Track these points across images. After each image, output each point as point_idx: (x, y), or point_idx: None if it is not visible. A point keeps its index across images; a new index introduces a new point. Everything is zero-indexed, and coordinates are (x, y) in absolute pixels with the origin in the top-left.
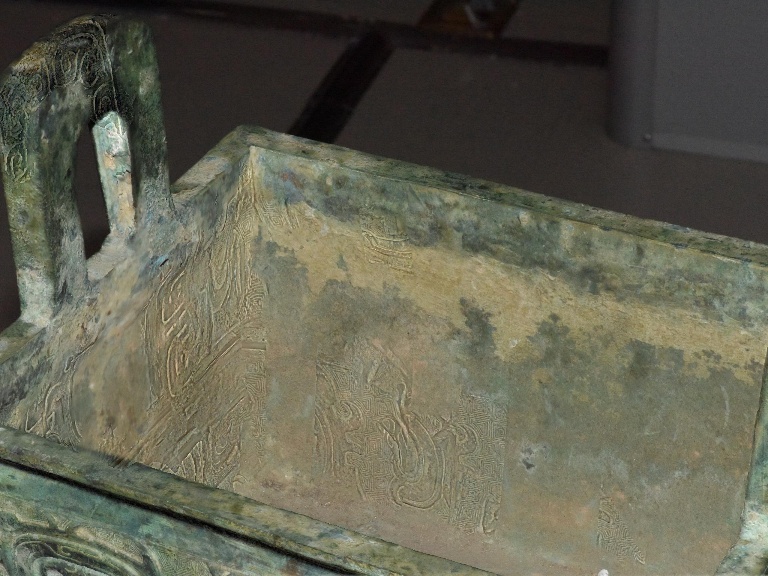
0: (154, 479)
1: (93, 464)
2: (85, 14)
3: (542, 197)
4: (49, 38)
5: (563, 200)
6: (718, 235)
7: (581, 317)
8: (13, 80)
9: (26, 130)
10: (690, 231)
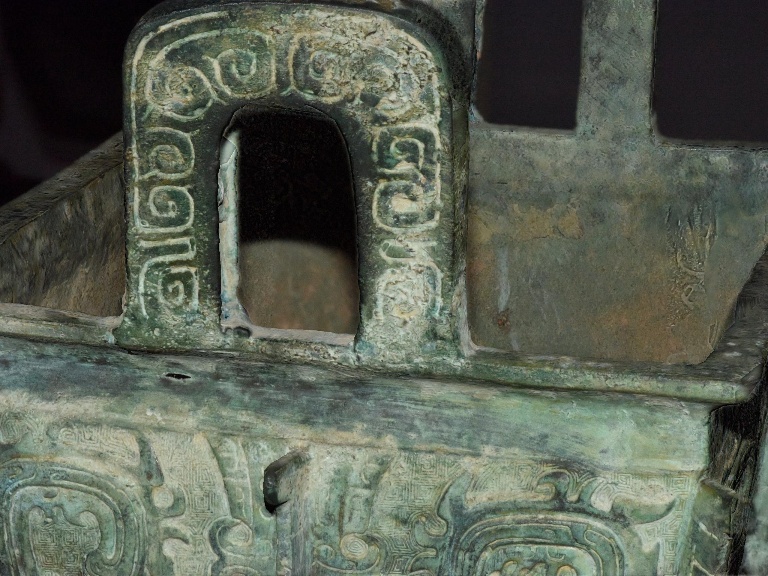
0: (764, 288)
1: (762, 308)
2: (197, 1)
3: (34, 194)
4: (274, 12)
5: (38, 188)
6: (109, 143)
7: (95, 307)
8: (376, 39)
9: (361, 121)
10: (101, 151)
